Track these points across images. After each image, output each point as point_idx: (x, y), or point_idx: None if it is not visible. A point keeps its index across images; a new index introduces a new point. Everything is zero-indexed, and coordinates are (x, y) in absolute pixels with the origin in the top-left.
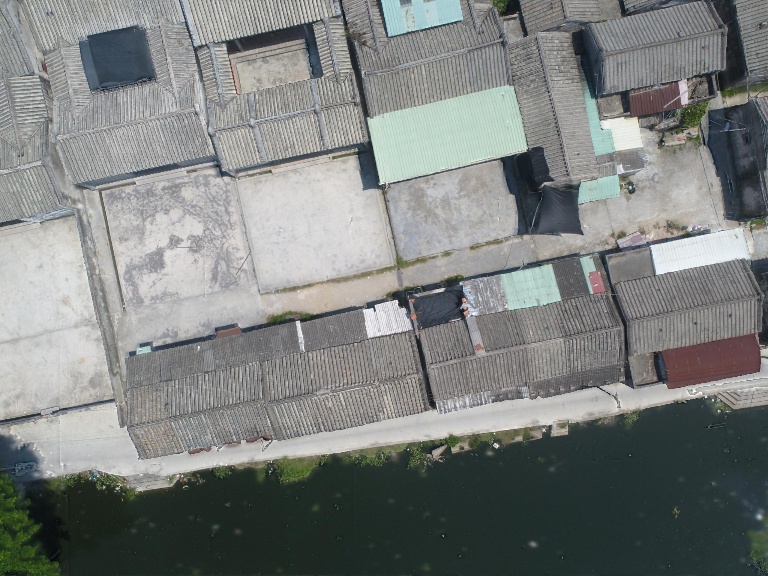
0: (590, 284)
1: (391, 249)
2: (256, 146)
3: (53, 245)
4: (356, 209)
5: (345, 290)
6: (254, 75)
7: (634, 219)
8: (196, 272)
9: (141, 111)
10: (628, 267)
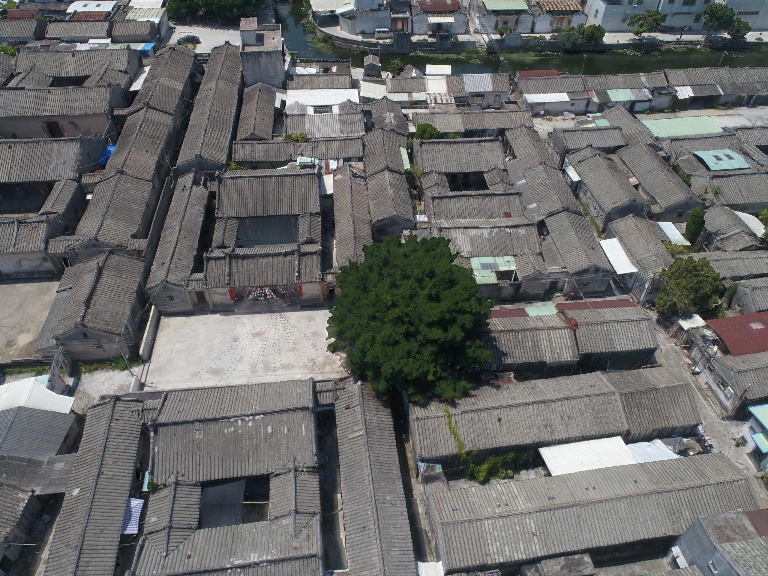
0: (594, 94)
1: None
2: None
3: None
4: None
5: (701, 114)
6: None
7: (568, 123)
8: None
9: None
10: (579, 95)
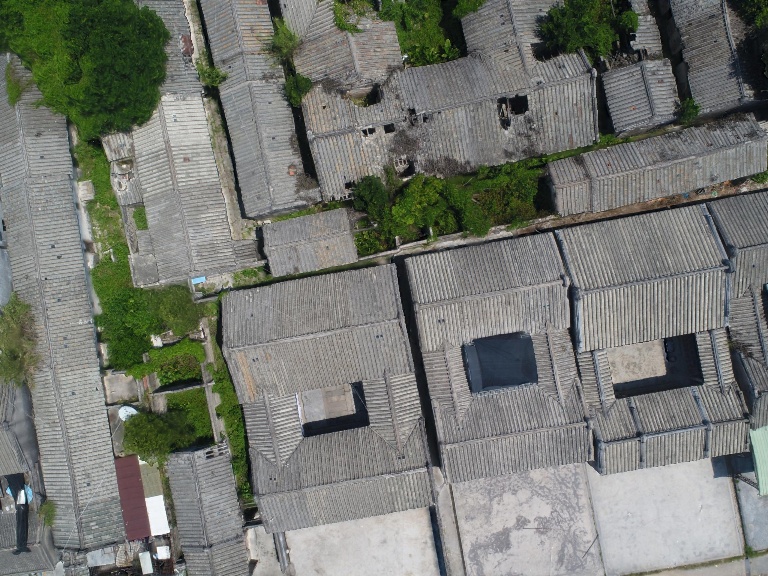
0: None
1: (740, 538)
2: (639, 456)
3: (397, 520)
4: (706, 497)
5: None
6: (608, 358)
7: None
8: (542, 554)
9: (527, 419)
10: None
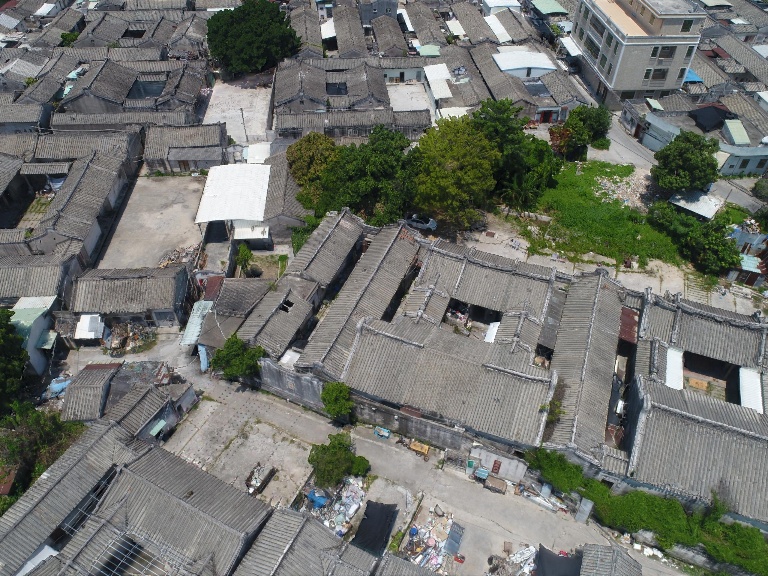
0: None
1: None
2: None
3: None
4: None
5: None
6: None
7: None
8: None
9: None
10: None
